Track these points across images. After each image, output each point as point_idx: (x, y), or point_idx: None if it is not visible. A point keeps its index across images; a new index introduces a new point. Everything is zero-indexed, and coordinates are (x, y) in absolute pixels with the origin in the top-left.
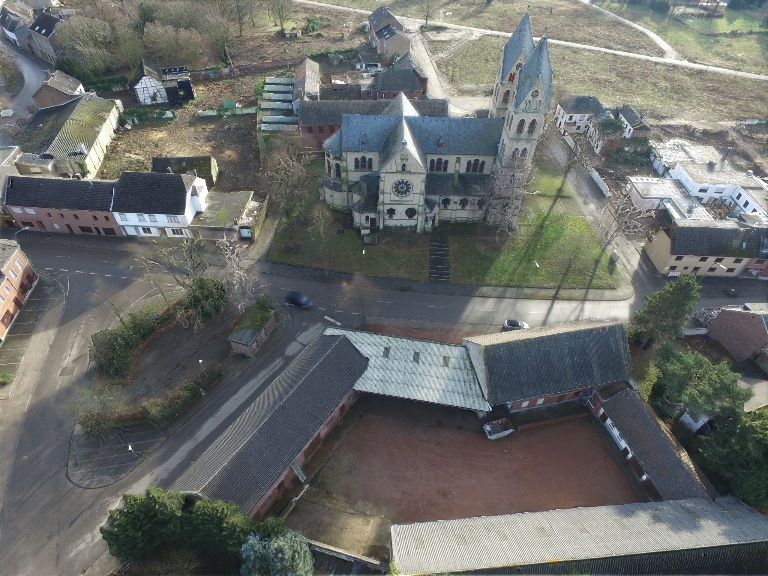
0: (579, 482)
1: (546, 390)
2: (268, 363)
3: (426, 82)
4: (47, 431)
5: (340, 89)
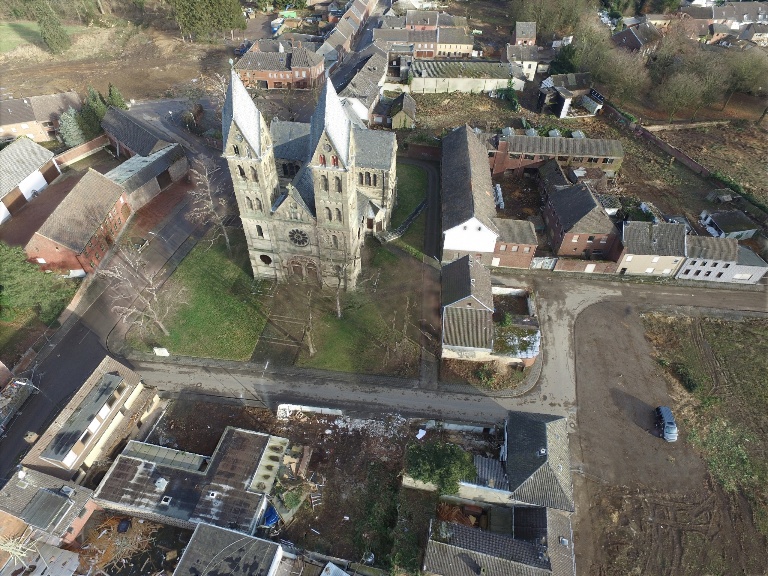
0: (14, 238)
1: None
2: (198, 149)
3: (621, 252)
4: (206, 104)
5: (559, 172)
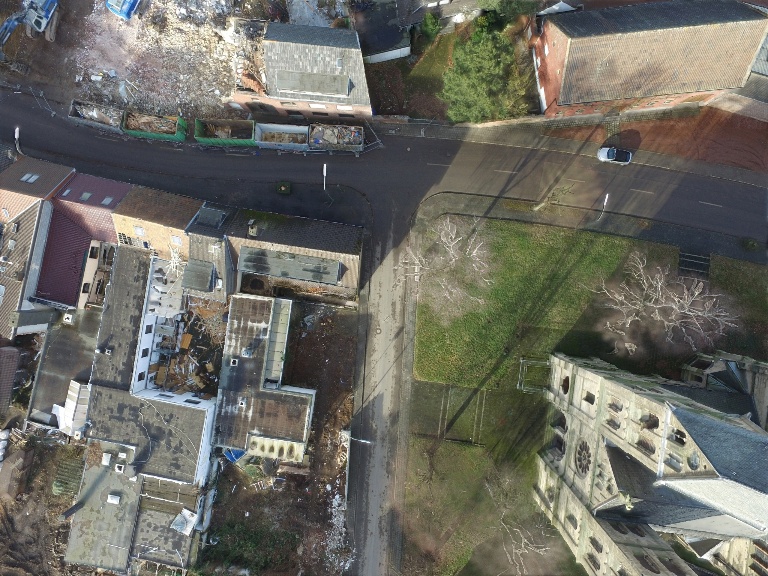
0: None
1: (662, 5)
2: None
3: None
4: None
5: None
